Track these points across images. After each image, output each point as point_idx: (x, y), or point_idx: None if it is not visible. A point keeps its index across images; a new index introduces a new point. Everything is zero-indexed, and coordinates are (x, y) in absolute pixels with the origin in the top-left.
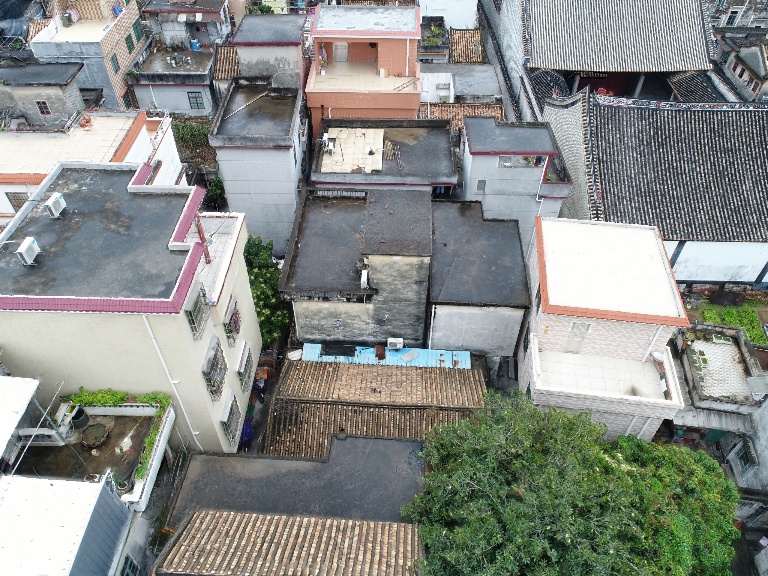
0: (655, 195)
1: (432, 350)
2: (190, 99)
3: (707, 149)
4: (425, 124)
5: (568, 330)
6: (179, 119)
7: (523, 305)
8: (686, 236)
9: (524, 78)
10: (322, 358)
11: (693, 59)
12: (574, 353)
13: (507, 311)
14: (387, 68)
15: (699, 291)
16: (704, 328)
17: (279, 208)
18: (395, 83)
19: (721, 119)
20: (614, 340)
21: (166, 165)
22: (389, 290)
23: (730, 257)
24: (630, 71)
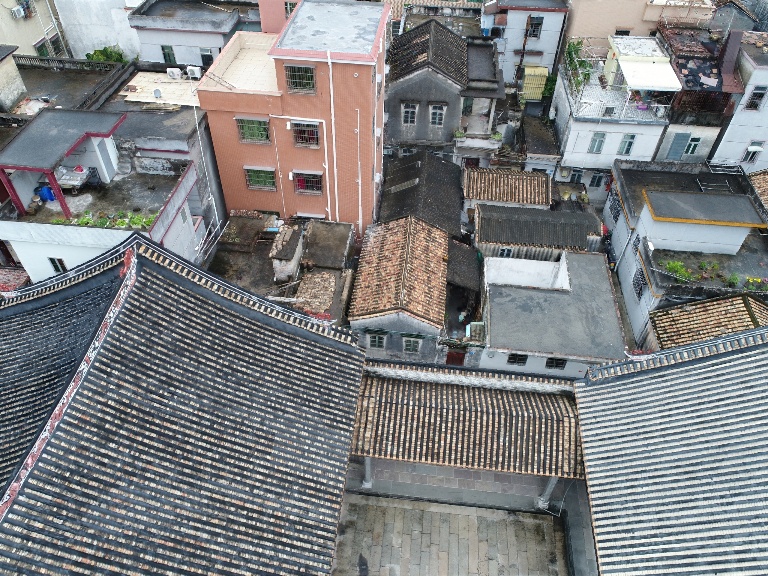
0: None
1: None
2: None
3: None
4: None
5: None
6: None
7: None
8: None
9: None
10: None
11: None
12: None
13: None
14: None
15: None
16: None
17: None
18: None
19: None
20: None
21: None
22: None
23: None
24: None
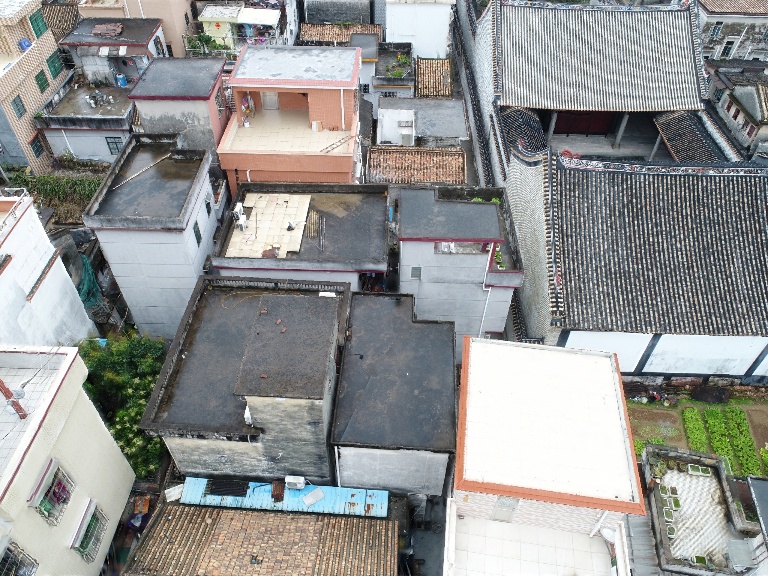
0: (627, 277)
1: (342, 488)
2: (109, 144)
3: (689, 221)
4: (360, 189)
5: (493, 500)
6: (97, 167)
7: (445, 450)
8: (662, 328)
9: (494, 117)
10: (205, 499)
11: (682, 98)
12: (504, 521)
13: (428, 453)
14: (320, 121)
15: (679, 384)
16: (678, 455)
17: (180, 293)
18: (328, 139)
19: (706, 185)
20: (552, 513)
21: (23, 256)
22: (278, 430)
23: (715, 350)
24: (612, 110)
